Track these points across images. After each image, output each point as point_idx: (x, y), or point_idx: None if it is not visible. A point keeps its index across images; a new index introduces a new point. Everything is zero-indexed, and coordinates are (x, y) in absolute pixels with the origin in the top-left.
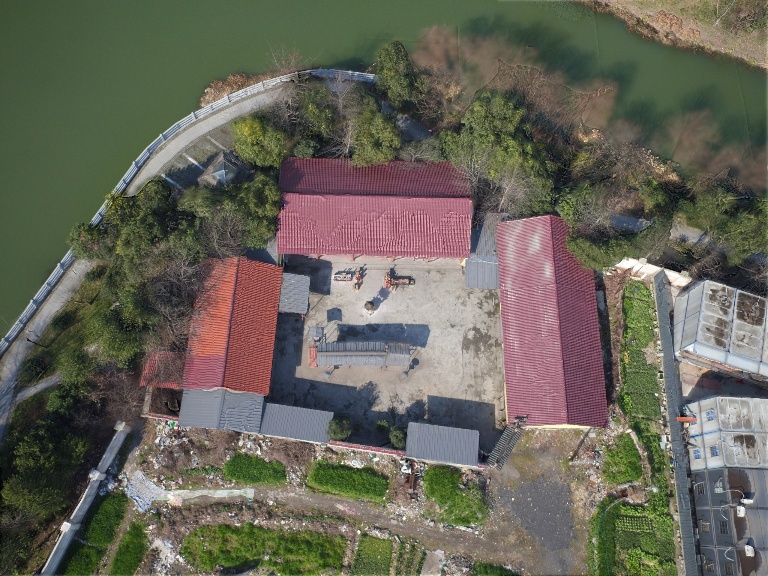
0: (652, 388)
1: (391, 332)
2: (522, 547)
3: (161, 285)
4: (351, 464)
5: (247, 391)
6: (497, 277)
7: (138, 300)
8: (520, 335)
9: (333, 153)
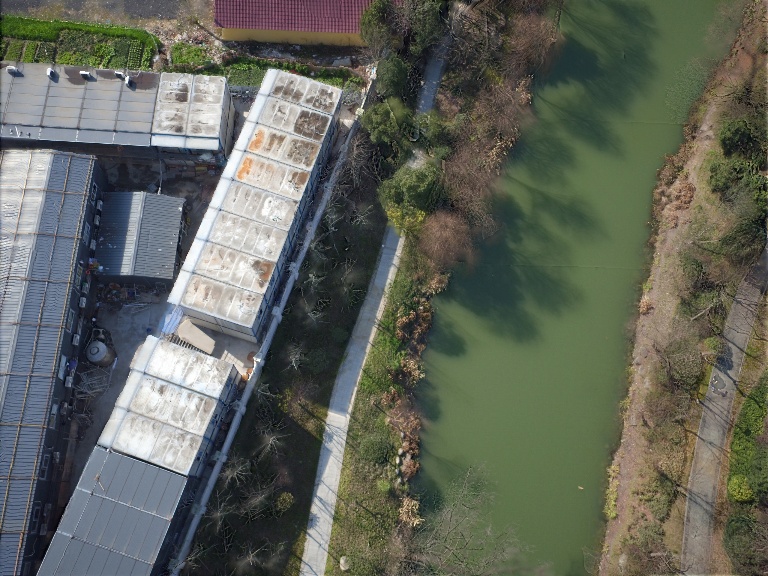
0: None
1: None
2: None
3: None
4: None
5: None
6: None
7: None
8: None
9: None
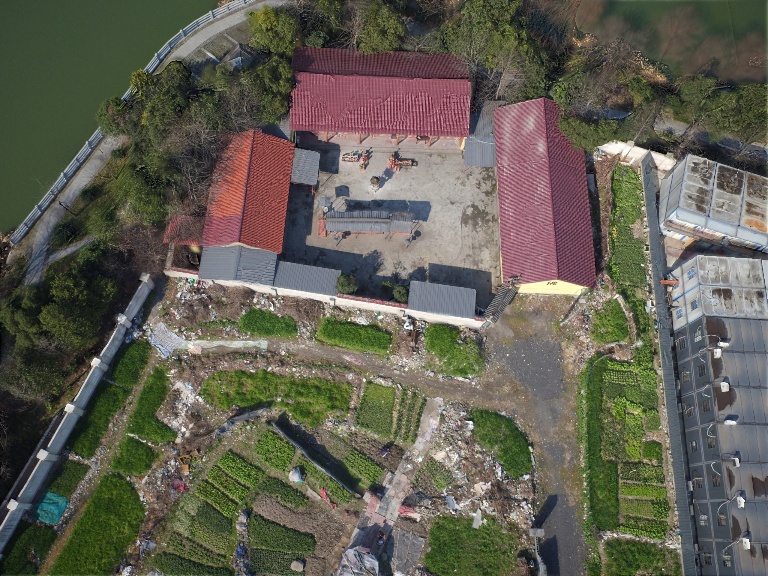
0: (638, 259)
1: (395, 207)
2: (516, 397)
3: (183, 149)
4: (357, 321)
5: (262, 248)
6: (494, 156)
7: (162, 162)
8: (515, 205)
9: (342, 43)
